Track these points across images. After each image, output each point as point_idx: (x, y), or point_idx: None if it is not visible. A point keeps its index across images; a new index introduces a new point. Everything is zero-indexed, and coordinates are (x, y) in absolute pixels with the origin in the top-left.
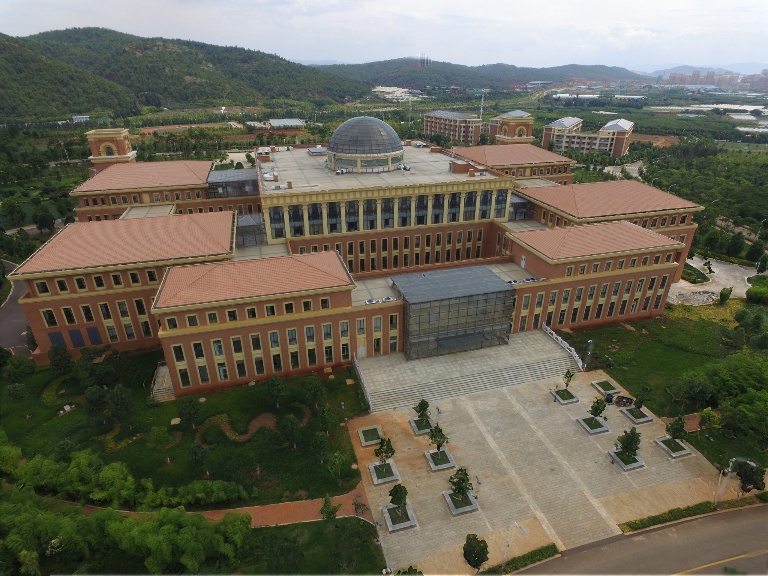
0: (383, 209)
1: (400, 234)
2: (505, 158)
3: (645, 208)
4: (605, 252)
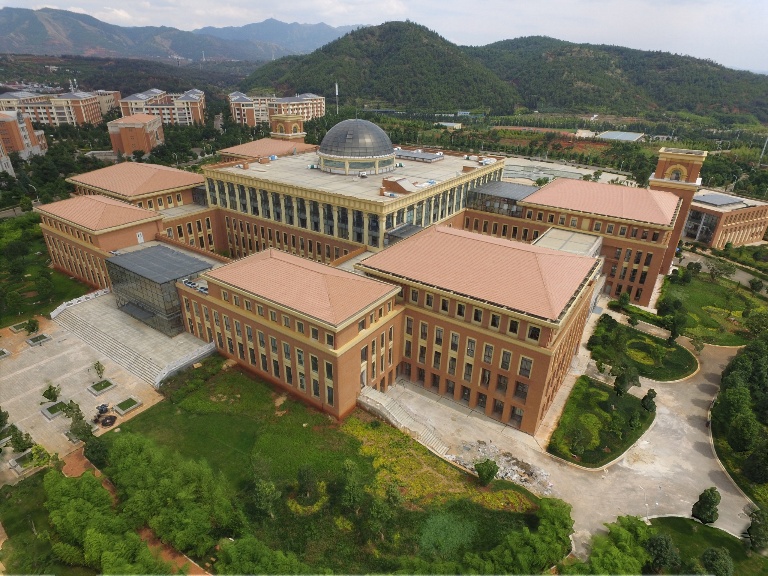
0: (275, 202)
1: (287, 230)
2: (565, 198)
3: (460, 287)
4: (250, 291)
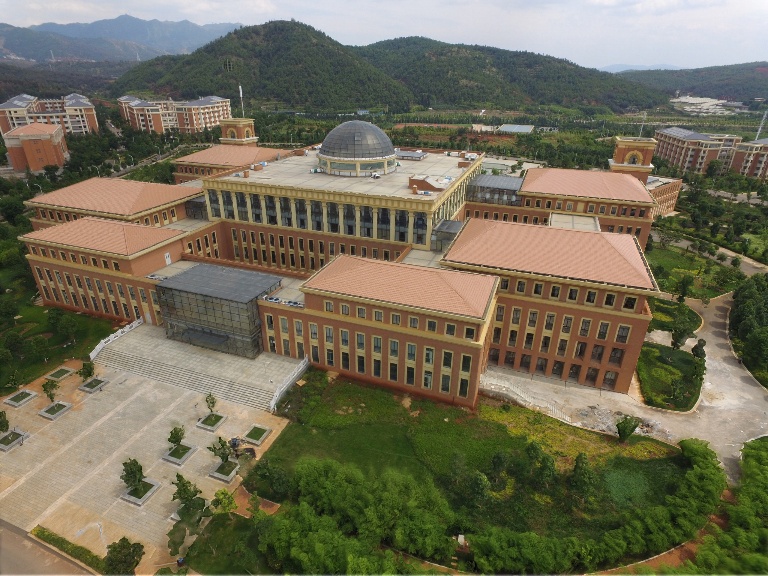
0: (299, 209)
1: (314, 237)
2: (557, 185)
3: (555, 270)
4: (368, 297)
